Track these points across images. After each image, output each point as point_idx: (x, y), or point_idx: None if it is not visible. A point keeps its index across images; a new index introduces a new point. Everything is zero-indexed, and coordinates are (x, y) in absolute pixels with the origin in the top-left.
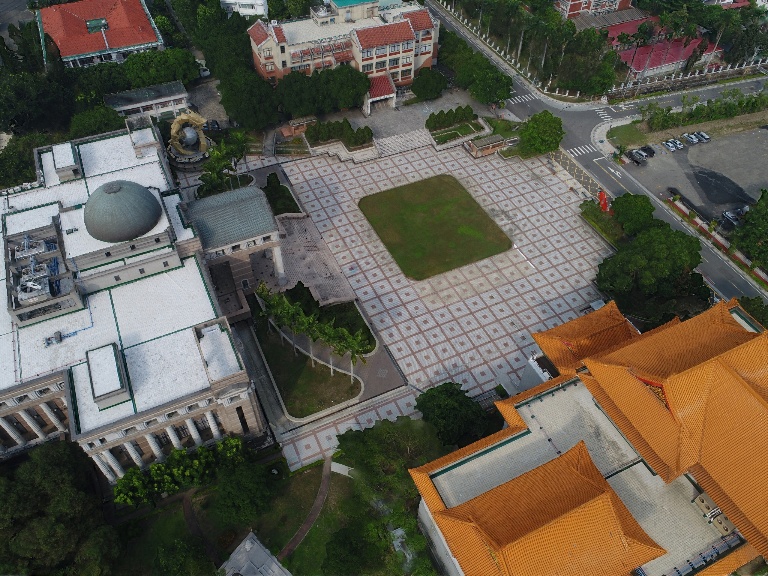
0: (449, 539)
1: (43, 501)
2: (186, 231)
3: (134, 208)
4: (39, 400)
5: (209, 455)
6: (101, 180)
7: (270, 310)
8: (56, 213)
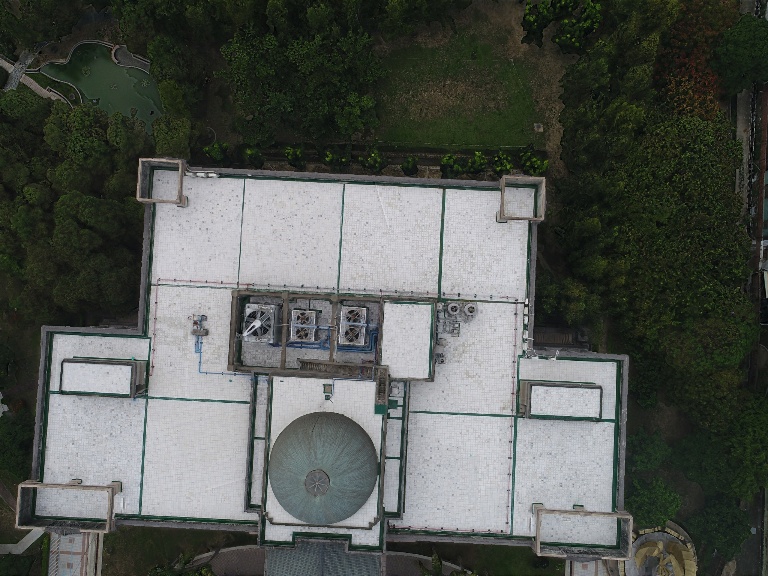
0: None
1: None
2: (287, 533)
3: (282, 496)
4: None
5: None
6: (499, 438)
7: (181, 569)
8: (405, 372)
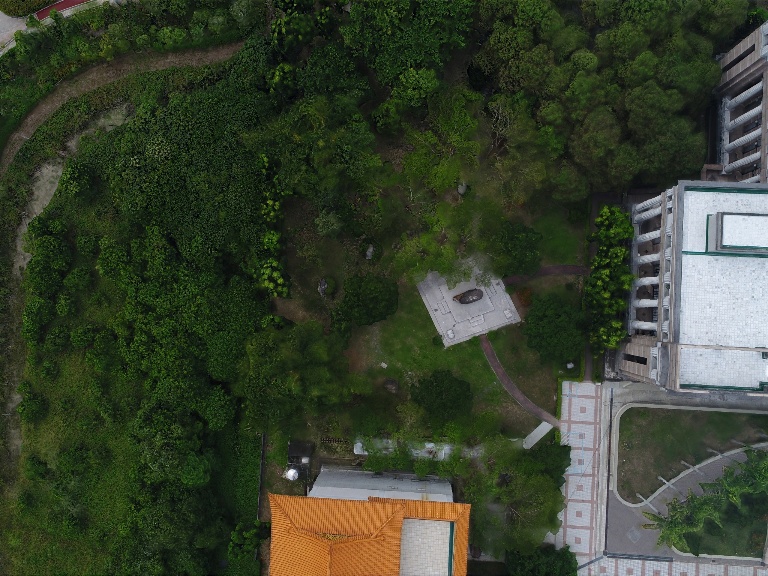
0: (376, 505)
1: (640, 140)
2: None
3: None
4: (766, 152)
5: (612, 310)
6: None
7: None
8: None
